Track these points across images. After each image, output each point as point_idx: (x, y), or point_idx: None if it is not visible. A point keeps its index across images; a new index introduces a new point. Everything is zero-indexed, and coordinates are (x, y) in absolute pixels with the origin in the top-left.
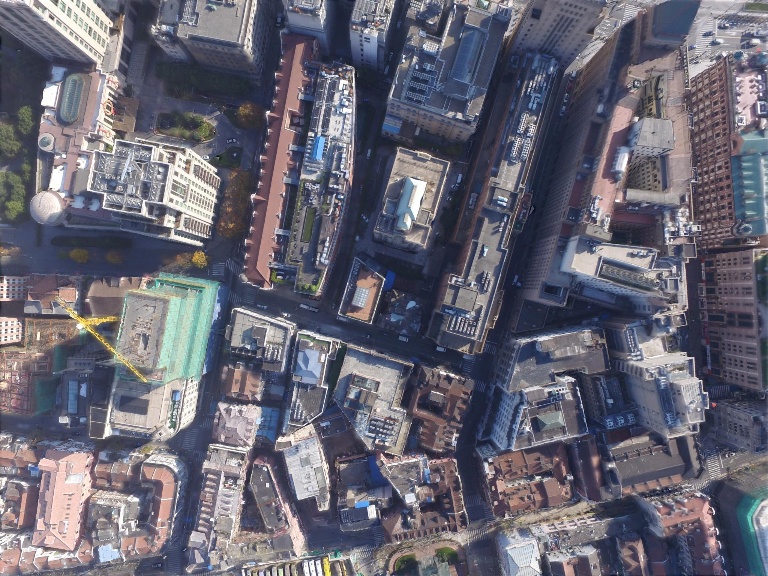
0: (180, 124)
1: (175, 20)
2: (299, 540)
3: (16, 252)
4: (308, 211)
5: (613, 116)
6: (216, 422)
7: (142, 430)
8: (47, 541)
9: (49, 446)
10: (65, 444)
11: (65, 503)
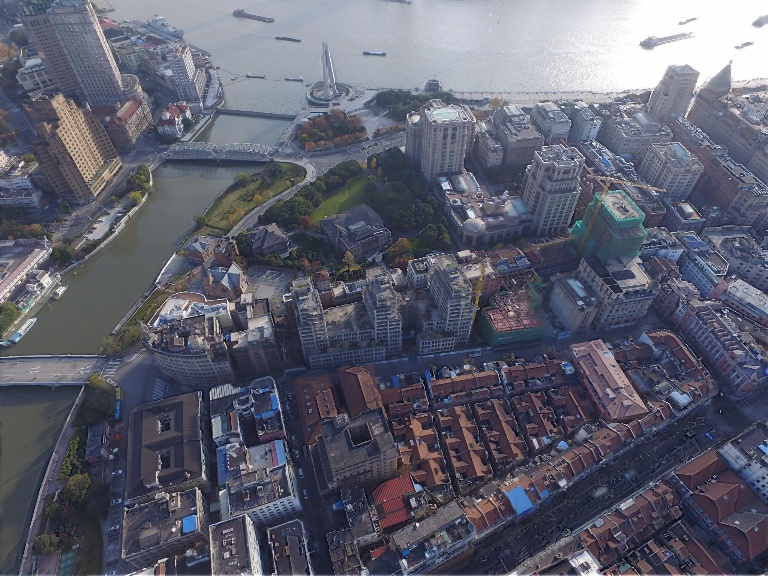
0: (511, 189)
1: None
2: None
3: None
4: None
5: (731, 111)
6: (670, 290)
7: (640, 288)
8: (626, 403)
9: (564, 351)
10: None
11: None
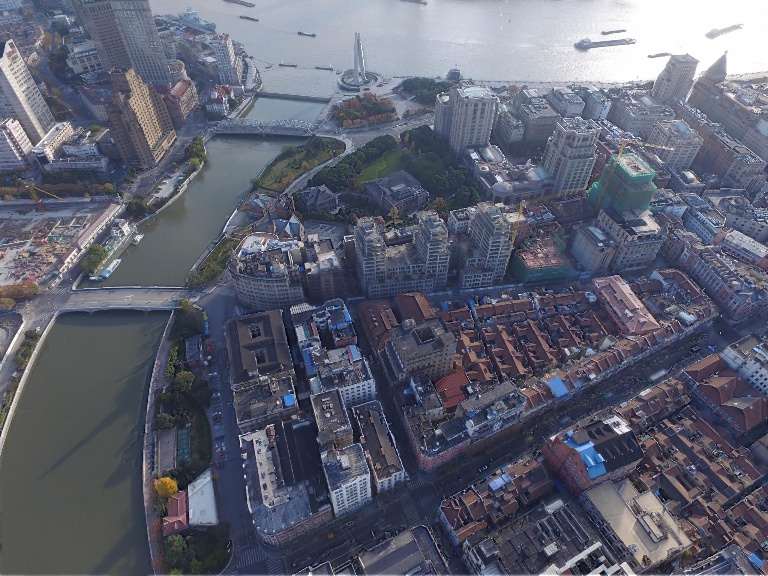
0: (532, 161)
1: None
2: None
3: None
4: None
5: (726, 95)
6: (676, 238)
7: (651, 233)
8: (642, 320)
9: (587, 285)
10: None
11: None
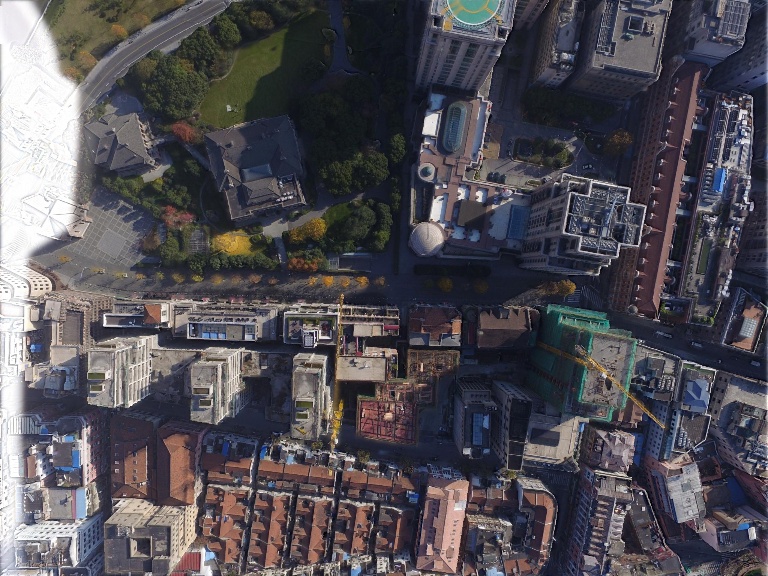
0: (543, 151)
1: (570, 47)
2: None
3: None
4: (704, 243)
5: None
6: (599, 450)
7: (550, 461)
8: (437, 566)
9: (423, 473)
10: (433, 470)
11: (451, 529)
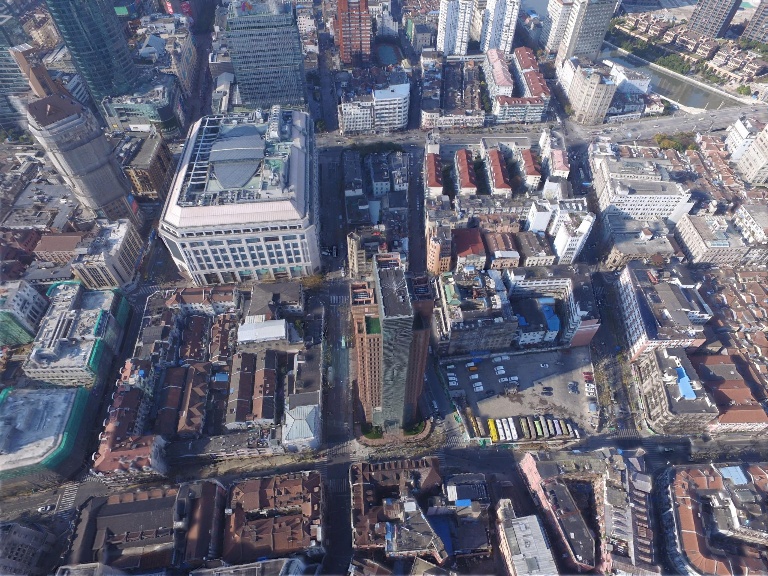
0: None
1: None
2: (528, 467)
3: None
4: None
5: None
6: None
7: None
8: None
9: None
10: None
11: None
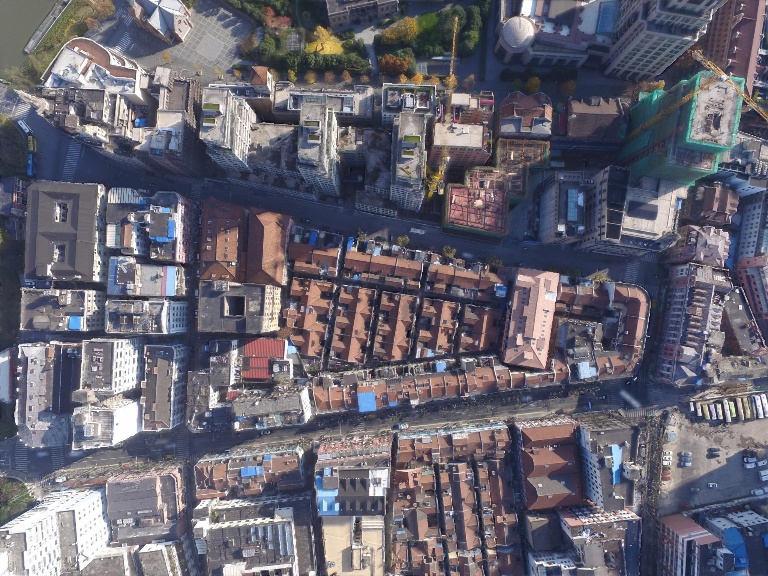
0: None
1: None
2: None
3: (469, 82)
4: None
5: None
6: (693, 241)
7: (648, 236)
8: (527, 356)
9: (511, 268)
10: None
11: (542, 319)
